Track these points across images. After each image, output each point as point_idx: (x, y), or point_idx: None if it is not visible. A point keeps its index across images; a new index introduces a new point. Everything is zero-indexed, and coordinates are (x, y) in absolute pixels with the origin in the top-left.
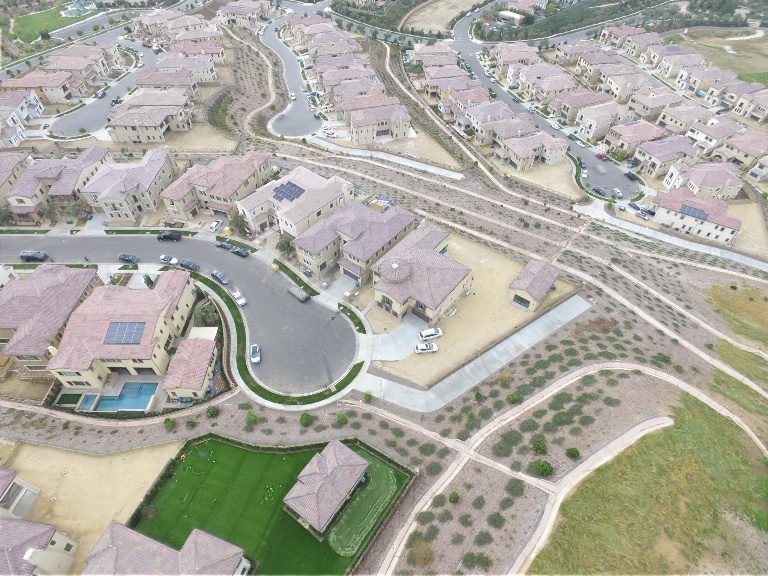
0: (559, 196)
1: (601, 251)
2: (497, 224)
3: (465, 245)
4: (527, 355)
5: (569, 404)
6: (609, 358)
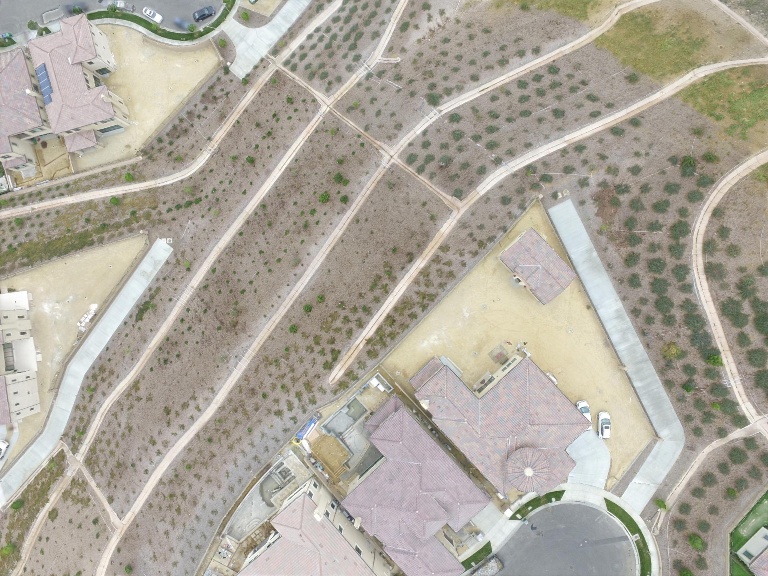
0: (205, 84)
1: (408, 109)
2: (338, 243)
3: (430, 330)
4: (635, 311)
5: (745, 308)
6: (688, 233)
